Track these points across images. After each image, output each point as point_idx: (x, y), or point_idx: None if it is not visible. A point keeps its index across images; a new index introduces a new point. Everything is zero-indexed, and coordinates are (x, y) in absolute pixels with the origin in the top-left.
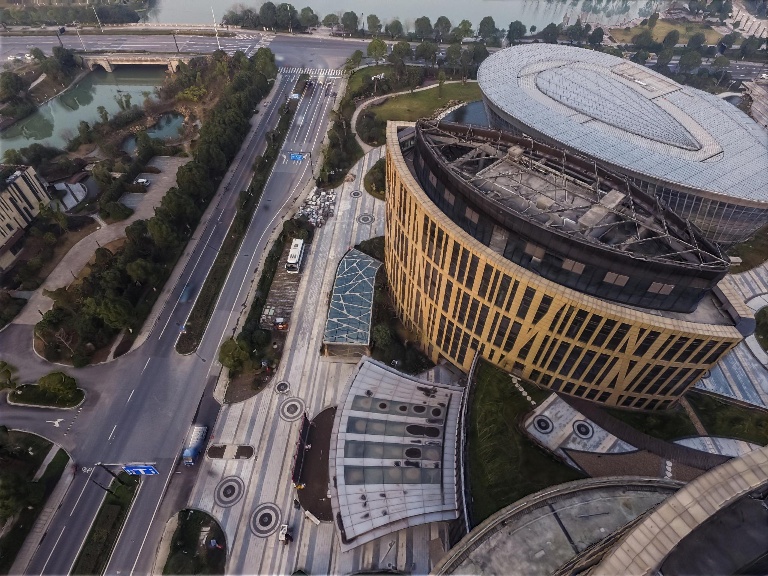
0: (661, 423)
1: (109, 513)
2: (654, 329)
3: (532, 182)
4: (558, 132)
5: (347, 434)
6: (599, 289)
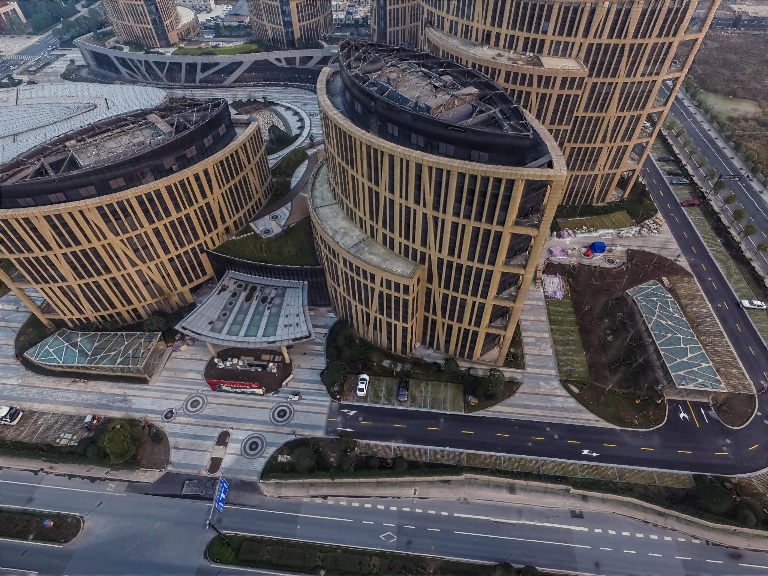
0: (281, 189)
1: (247, 550)
2: (243, 143)
3: (109, 146)
4: (14, 155)
5: (239, 335)
6: (208, 154)
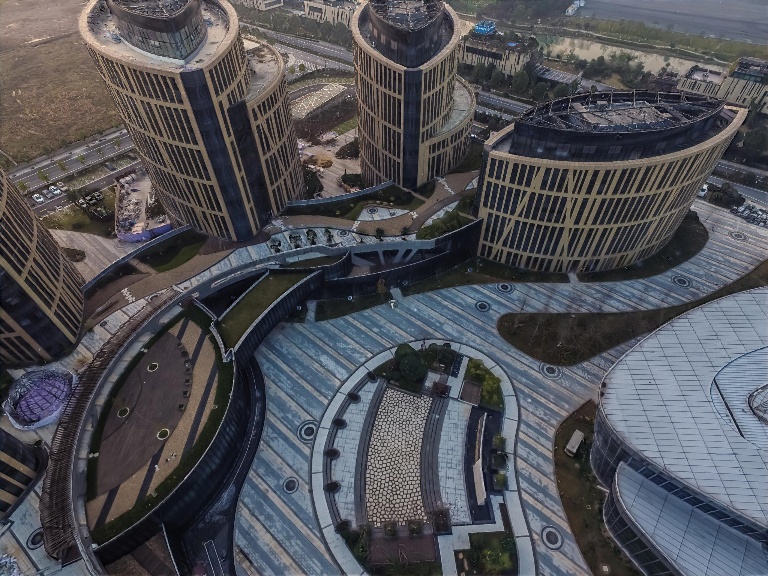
0: None
1: None
2: None
3: None
4: None
5: None
6: None
